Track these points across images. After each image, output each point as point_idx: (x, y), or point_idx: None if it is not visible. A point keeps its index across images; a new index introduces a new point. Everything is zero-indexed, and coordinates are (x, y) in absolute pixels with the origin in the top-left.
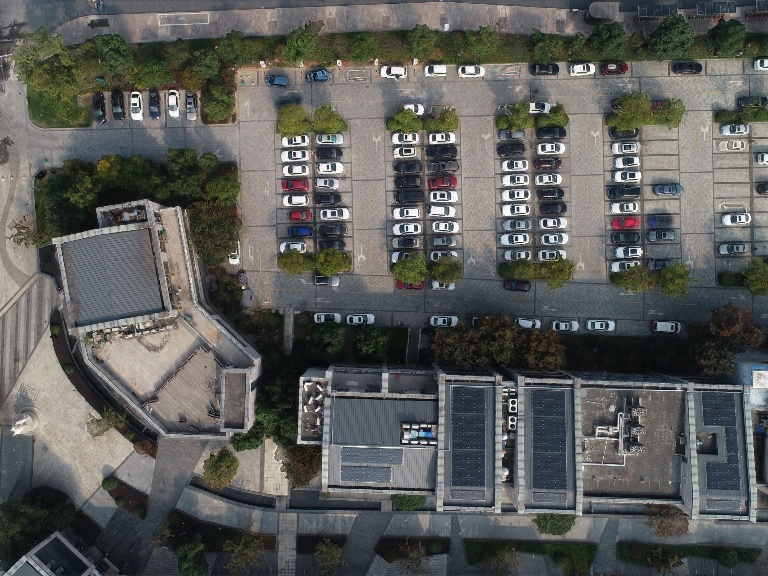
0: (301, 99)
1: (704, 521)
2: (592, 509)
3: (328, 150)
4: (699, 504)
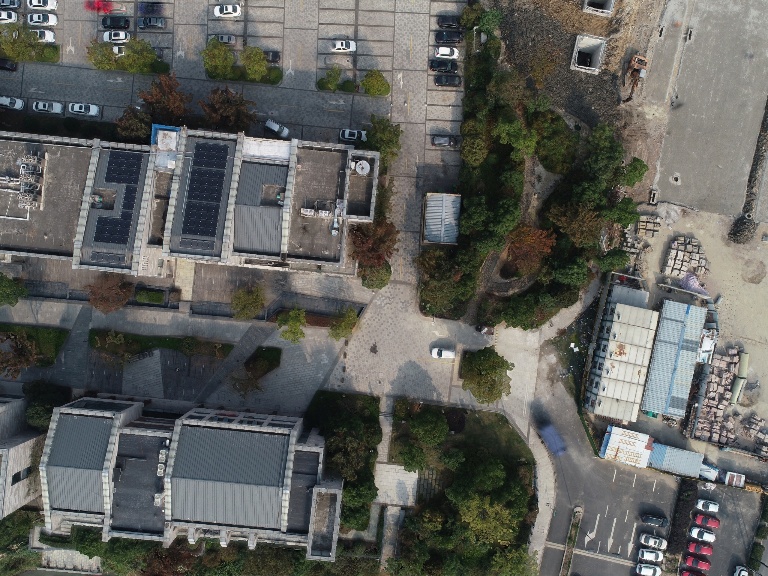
0: None
1: (178, 314)
2: (67, 295)
3: None
4: (84, 256)
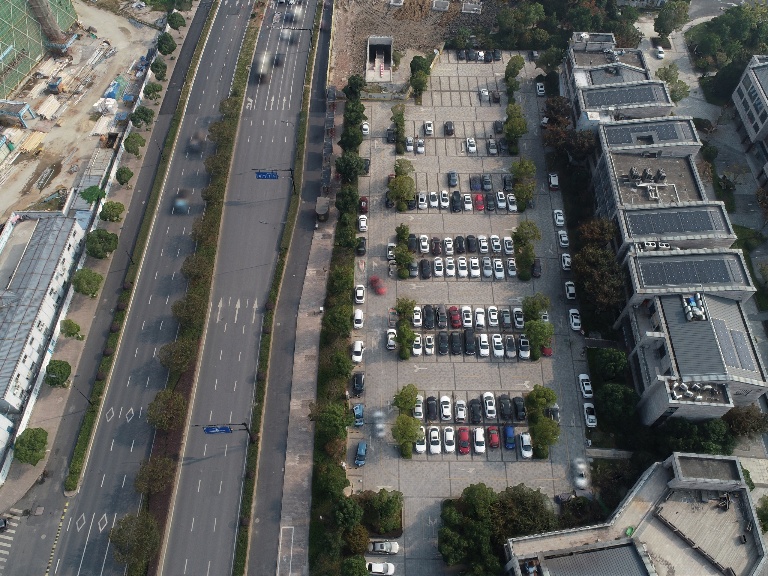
0: (378, 434)
1: None
2: None
3: (430, 407)
4: None
